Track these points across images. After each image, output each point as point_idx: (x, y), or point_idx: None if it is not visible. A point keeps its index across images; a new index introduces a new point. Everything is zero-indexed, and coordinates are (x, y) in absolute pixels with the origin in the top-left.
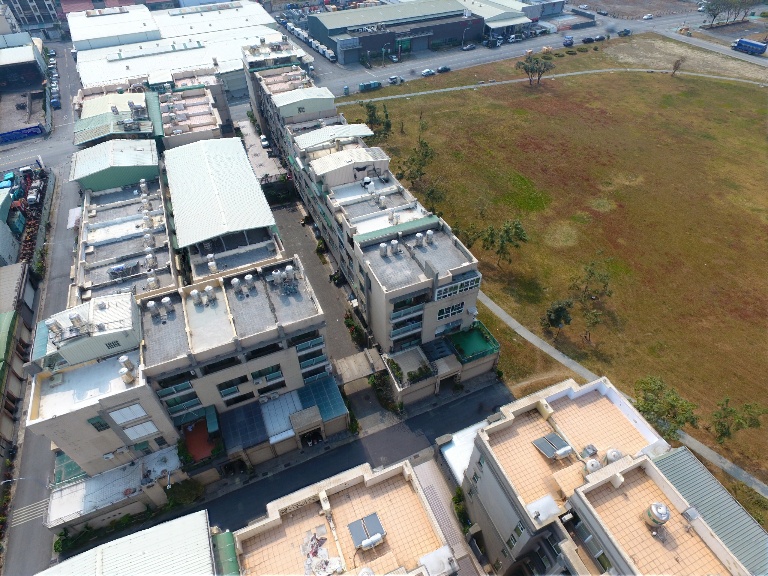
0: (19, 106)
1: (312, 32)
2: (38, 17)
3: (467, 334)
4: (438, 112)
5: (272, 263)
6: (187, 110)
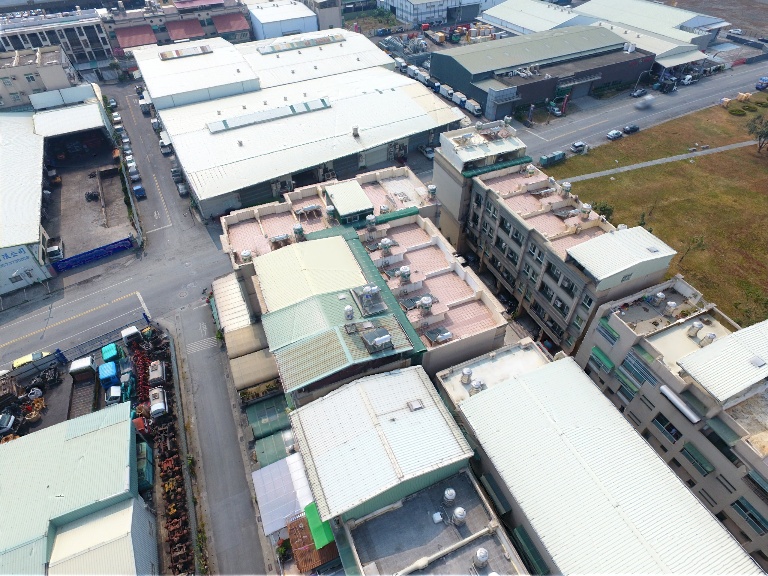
0: (90, 196)
1: (437, 73)
2: (89, 53)
3: None
4: (666, 202)
5: None
6: None
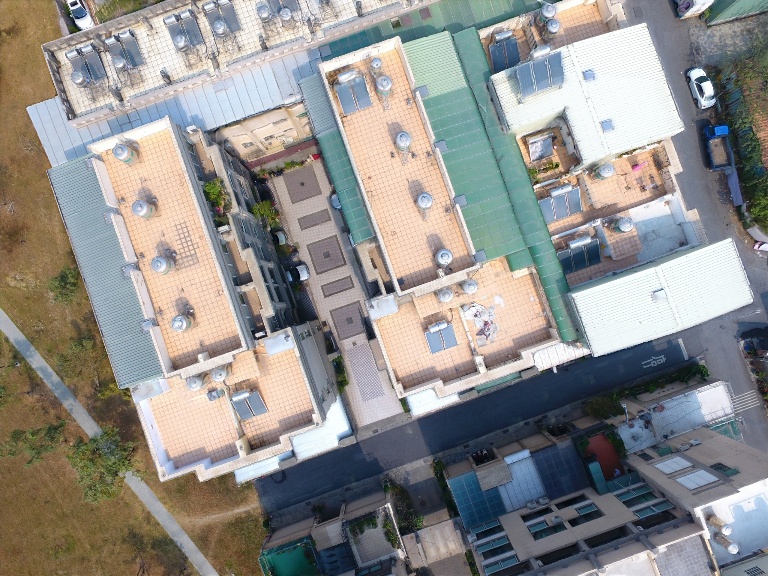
0: None
1: None
2: None
3: None
4: None
5: None
6: None
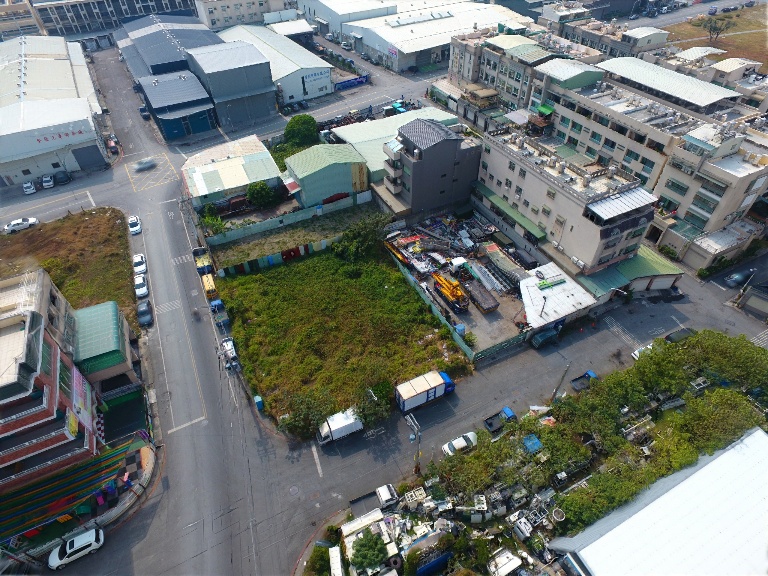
0: None
1: None
2: None
3: None
4: None
5: (763, 114)
6: None
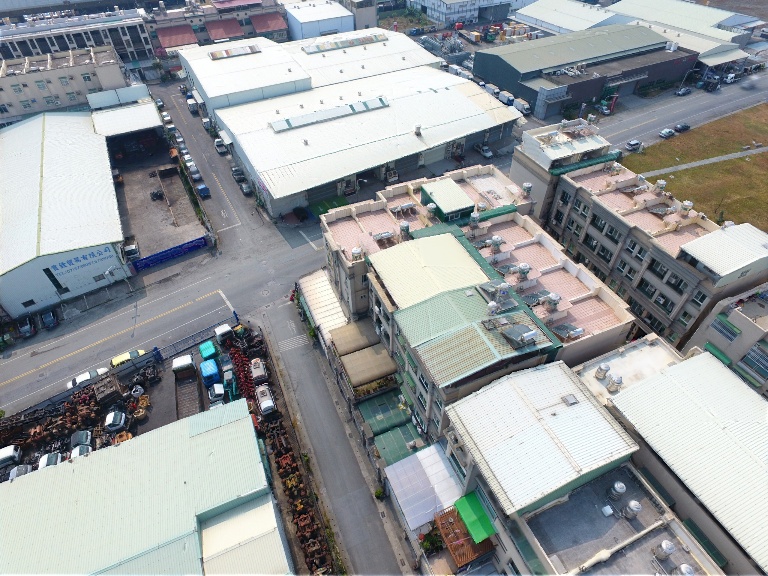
0: (155, 195)
1: (480, 72)
2: (131, 53)
3: None
4: (729, 200)
5: None
6: (526, 263)
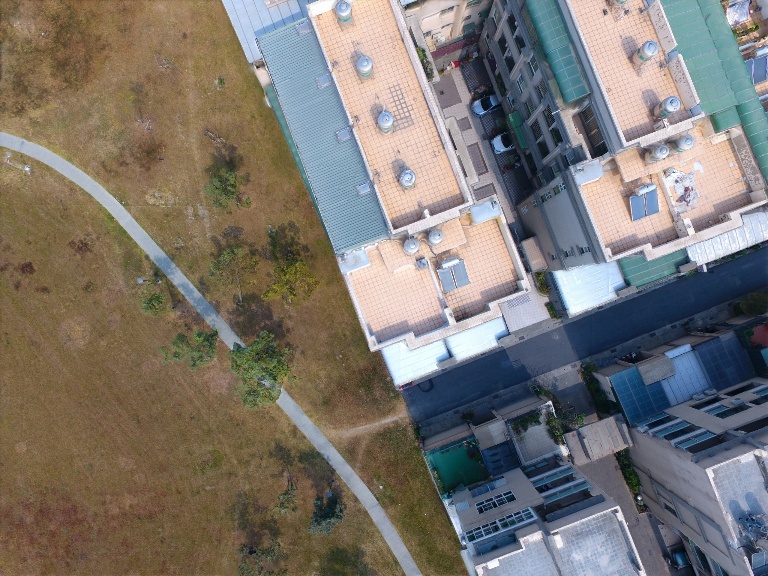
0: None
1: None
2: None
3: (458, 482)
4: None
5: None
6: None
